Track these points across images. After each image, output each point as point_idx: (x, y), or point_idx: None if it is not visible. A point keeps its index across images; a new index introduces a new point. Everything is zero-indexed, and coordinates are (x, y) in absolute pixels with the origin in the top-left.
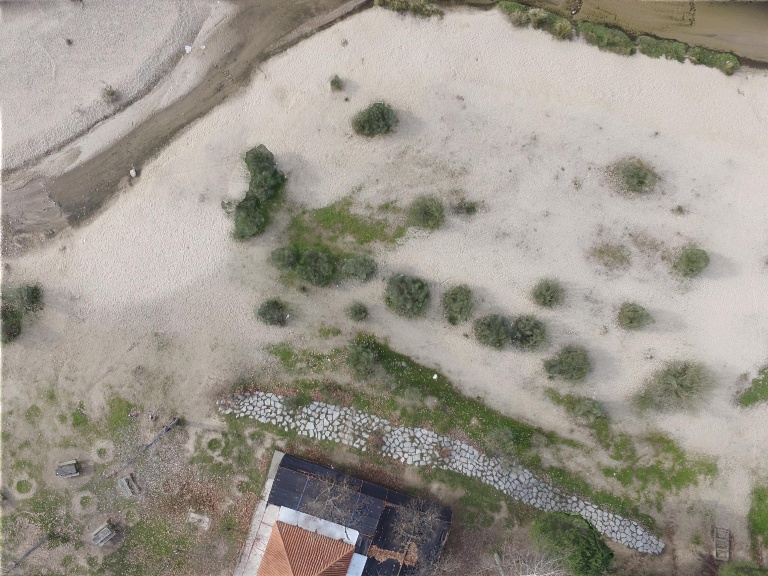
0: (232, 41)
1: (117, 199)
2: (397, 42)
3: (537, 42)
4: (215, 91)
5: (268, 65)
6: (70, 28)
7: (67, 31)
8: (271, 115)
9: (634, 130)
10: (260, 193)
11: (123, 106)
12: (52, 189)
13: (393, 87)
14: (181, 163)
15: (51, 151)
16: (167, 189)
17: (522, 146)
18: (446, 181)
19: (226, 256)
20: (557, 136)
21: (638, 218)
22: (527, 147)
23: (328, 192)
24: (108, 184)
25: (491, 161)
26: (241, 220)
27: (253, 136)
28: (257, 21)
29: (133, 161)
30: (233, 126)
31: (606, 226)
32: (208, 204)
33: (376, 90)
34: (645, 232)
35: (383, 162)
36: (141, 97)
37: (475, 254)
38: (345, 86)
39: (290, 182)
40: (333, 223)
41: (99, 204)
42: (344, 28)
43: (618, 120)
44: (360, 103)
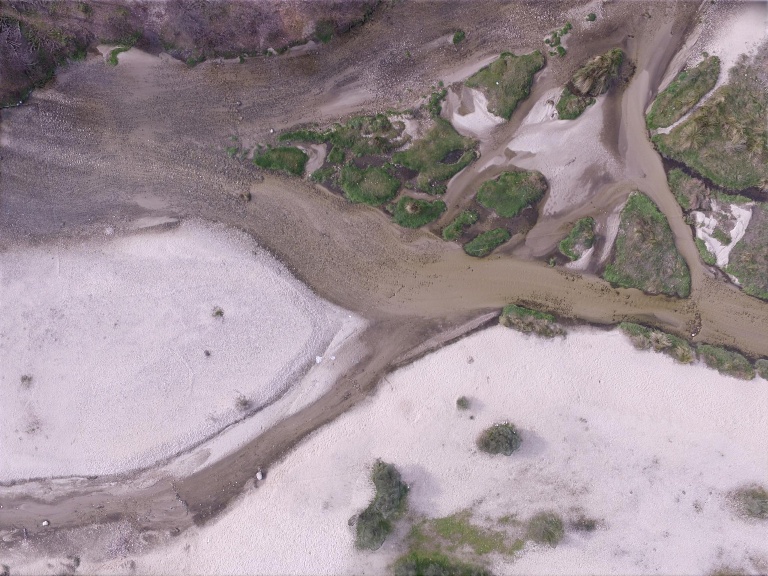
0: (361, 353)
1: (242, 500)
2: (521, 361)
3: (658, 365)
4: (342, 399)
5: (395, 377)
6: (209, 340)
7: (206, 343)
8: (397, 427)
9: (756, 458)
10: (387, 515)
11: (254, 411)
12: (180, 488)
13: (517, 407)
14: (307, 470)
15: (182, 452)
16: (292, 495)
17: (643, 469)
18: (567, 498)
19: (346, 562)
20: (679, 461)
21: (759, 543)
22: (648, 470)
23: (449, 503)
24: (234, 485)
25: (612, 482)
26: (367, 540)
27: (378, 447)
28: (386, 335)
29: (260, 463)
30: (359, 436)
31: (726, 549)
32: (331, 511)
33: (501, 409)
34: (766, 557)
35: (505, 478)
36: (271, 403)
37: (593, 570)
38: (471, 404)
39: (412, 492)
40: (453, 533)
41: (224, 504)
42: (470, 345)
43: (740, 448)
44: (485, 421)
